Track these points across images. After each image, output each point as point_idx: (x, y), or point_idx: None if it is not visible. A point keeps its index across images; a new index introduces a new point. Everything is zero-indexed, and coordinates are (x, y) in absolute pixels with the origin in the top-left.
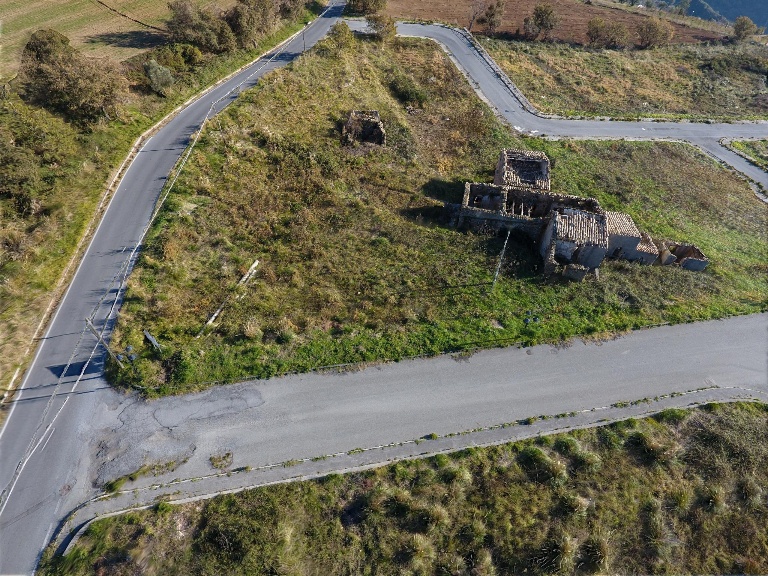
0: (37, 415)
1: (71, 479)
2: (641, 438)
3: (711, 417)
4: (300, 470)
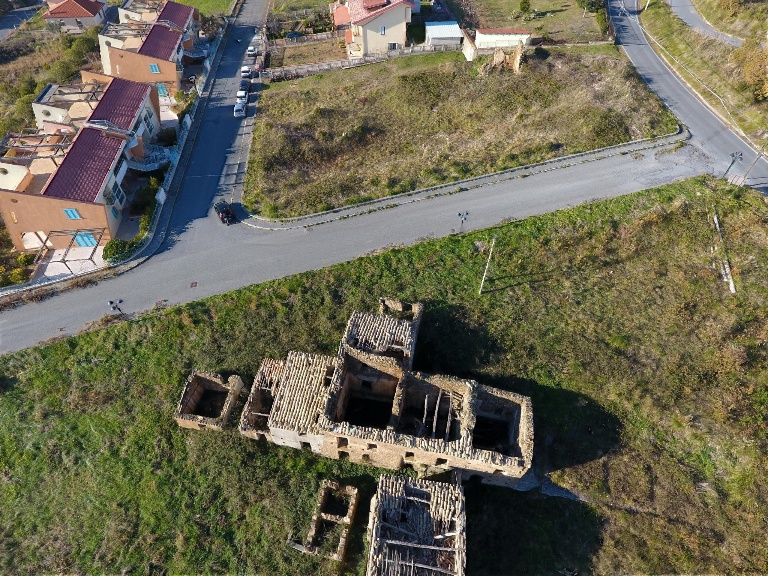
0: (760, 169)
1: (706, 147)
2: (392, 179)
3: (332, 199)
4: (592, 156)
